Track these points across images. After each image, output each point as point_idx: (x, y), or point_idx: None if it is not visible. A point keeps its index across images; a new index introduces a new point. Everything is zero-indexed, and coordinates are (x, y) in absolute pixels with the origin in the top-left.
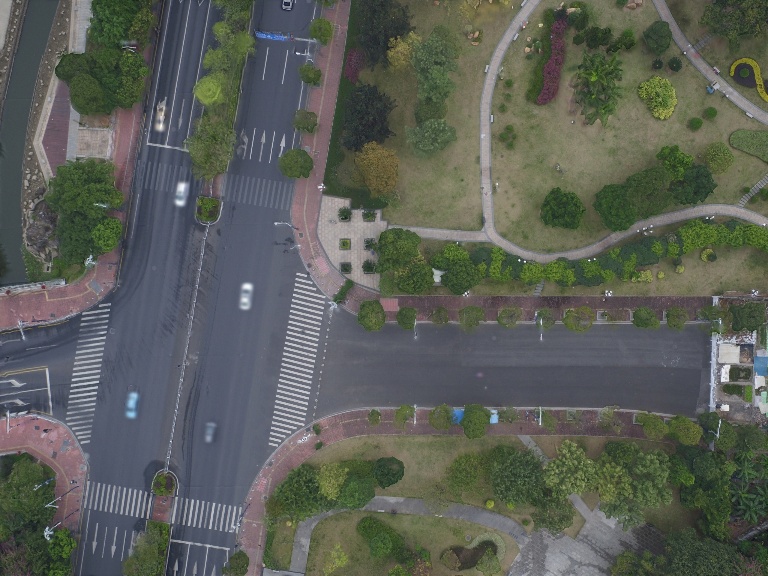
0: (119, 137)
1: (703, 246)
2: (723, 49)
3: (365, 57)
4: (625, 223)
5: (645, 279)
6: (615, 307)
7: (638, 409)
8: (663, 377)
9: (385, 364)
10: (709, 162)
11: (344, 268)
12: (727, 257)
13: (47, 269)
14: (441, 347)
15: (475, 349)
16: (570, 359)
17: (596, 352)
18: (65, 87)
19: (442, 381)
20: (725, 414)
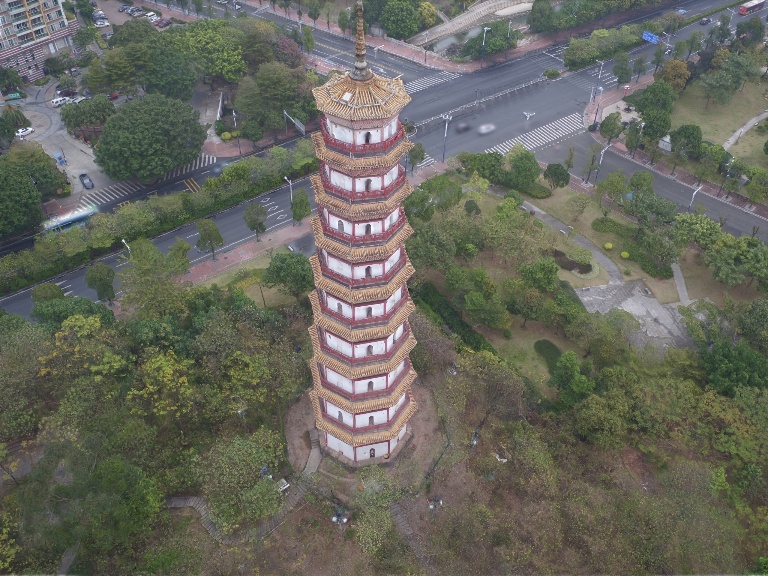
0: (531, 45)
1: None
2: None
3: None
4: None
5: None
6: None
7: None
8: None
9: None
10: None
11: None
12: None
13: None
14: None
15: (664, 188)
16: (735, 225)
17: None
18: None
19: None
20: None
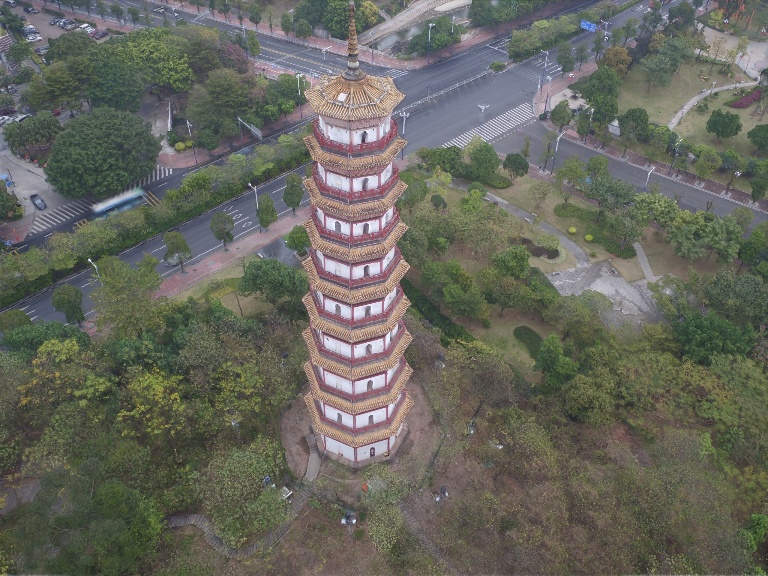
0: (474, 39)
1: None
2: None
3: (635, 49)
4: None
5: None
6: (739, 195)
7: None
8: None
9: None
10: None
11: None
12: None
13: None
14: None
15: (617, 171)
16: (687, 201)
17: None
18: None
19: None
20: None
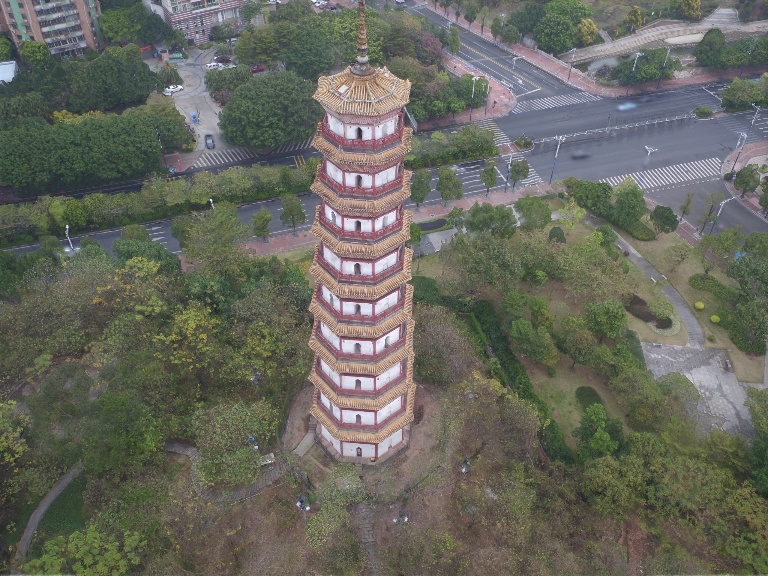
0: (692, 79)
1: None
2: None
3: None
4: None
5: None
6: None
7: None
8: None
9: None
10: None
11: None
12: None
13: None
14: None
15: None
16: None
17: None
18: (688, 61)
19: None
20: None
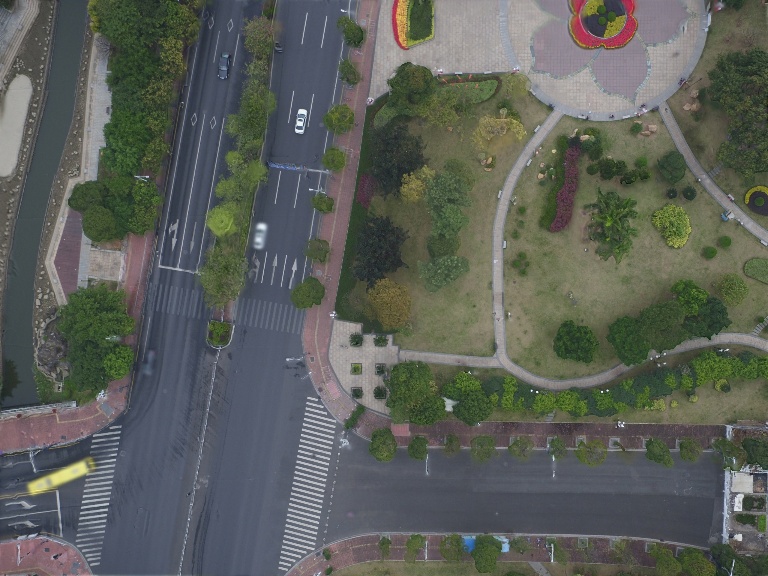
0: (131, 259)
1: (717, 379)
2: (738, 176)
3: (378, 187)
4: (639, 359)
5: (658, 408)
6: (627, 434)
7: (650, 537)
8: (676, 505)
9: (396, 489)
10: (723, 295)
11: (355, 394)
12: (741, 387)
13: (58, 388)
14: (452, 472)
15: (486, 475)
16: (582, 486)
17: (608, 479)
18: None
19: (453, 506)
20: (738, 544)
